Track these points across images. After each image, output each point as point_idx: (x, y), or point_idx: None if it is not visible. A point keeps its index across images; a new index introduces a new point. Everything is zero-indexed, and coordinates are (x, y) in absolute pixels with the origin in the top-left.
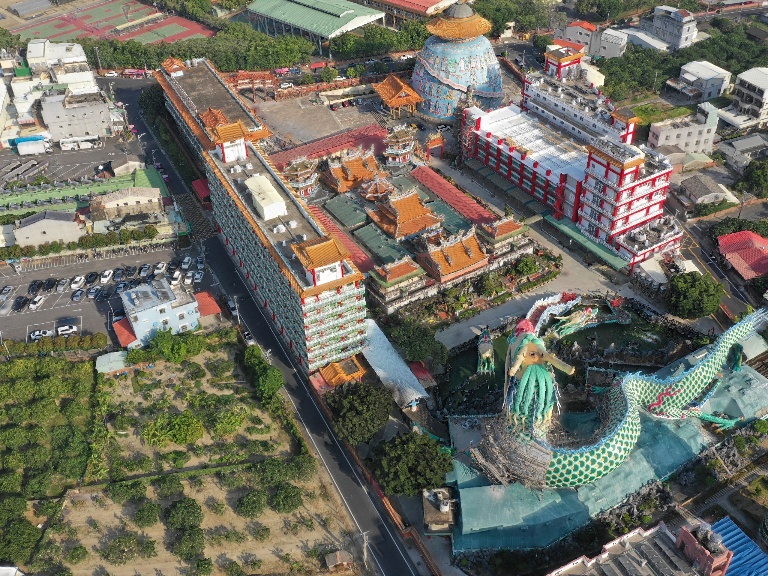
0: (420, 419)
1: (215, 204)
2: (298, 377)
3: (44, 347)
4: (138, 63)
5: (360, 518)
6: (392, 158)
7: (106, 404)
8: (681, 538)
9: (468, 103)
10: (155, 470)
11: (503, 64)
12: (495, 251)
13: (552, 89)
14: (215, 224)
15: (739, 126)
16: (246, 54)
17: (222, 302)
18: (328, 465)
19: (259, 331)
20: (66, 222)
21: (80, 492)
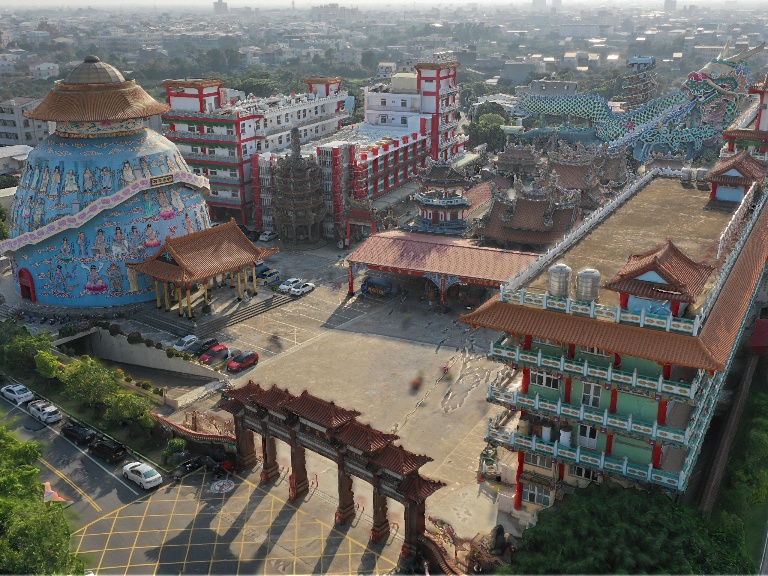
0: None
1: None
2: None
3: None
4: None
5: None
6: None
7: None
8: None
9: None
10: None
11: None
12: None
13: None
14: None
15: None
16: (52, 522)
17: None
18: None
19: None
20: None
21: None
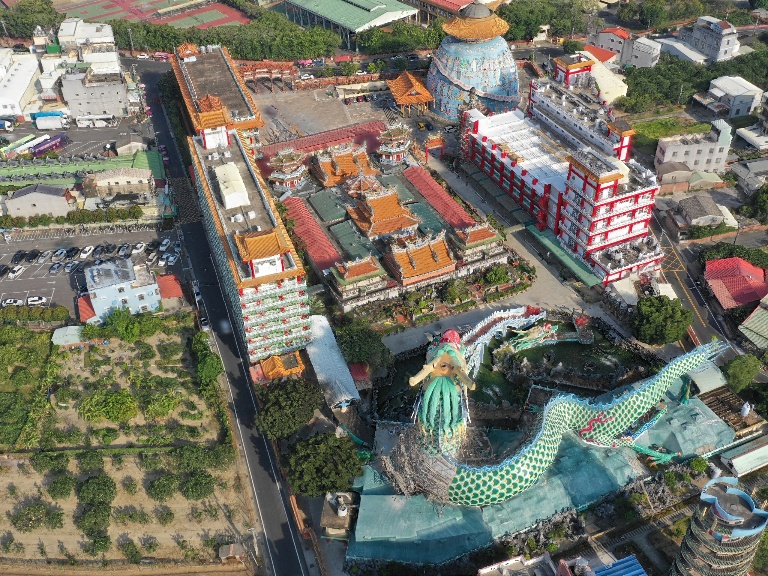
0: (347, 421)
1: (198, 189)
2: (242, 367)
3: (8, 315)
4: (168, 47)
5: (266, 513)
6: (386, 156)
7: (53, 375)
8: (560, 571)
9: (471, 105)
10: (84, 444)
11: (529, 68)
12: (465, 258)
13: (556, 96)
14: (201, 209)
15: (759, 147)
16: (271, 43)
17: (188, 286)
18: (249, 457)
19: (217, 318)
20: (55, 196)
21: (9, 458)
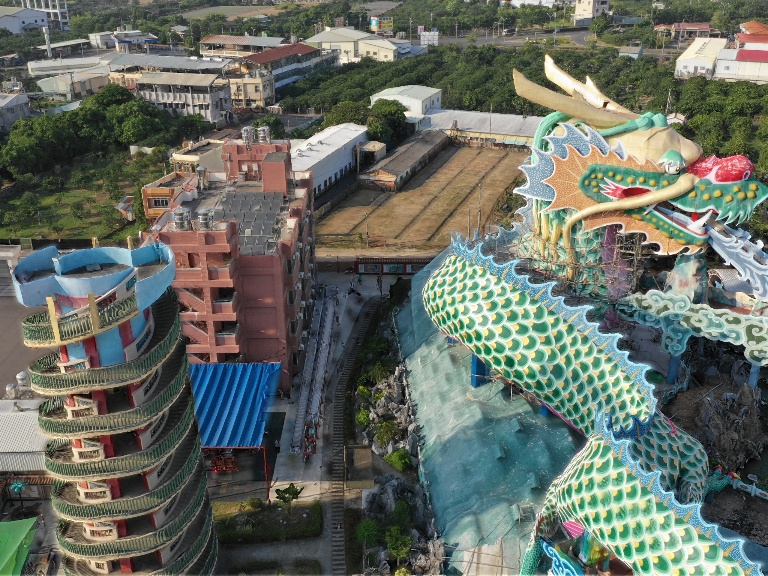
0: None
1: None
2: None
3: None
4: None
5: None
6: None
7: None
8: None
9: None
10: None
11: None
12: None
13: None
14: None
15: None
16: None
17: None
18: None
19: None
20: None
21: None
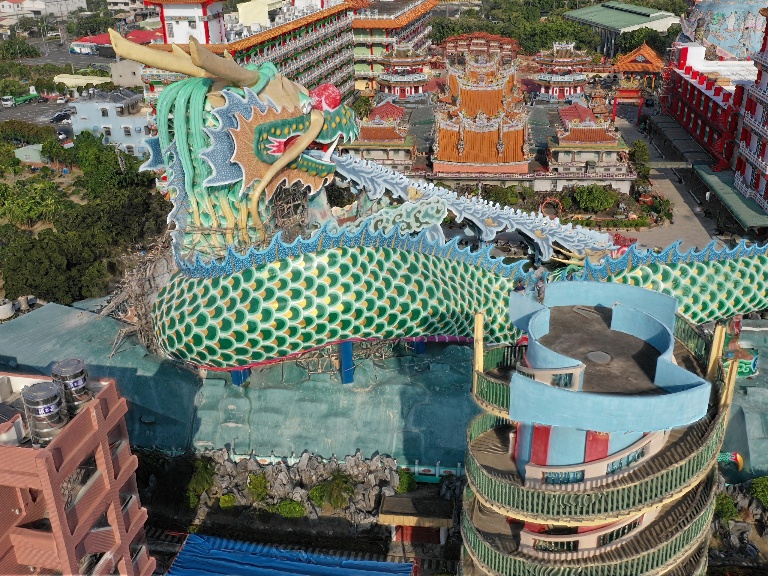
0: None
1: None
2: None
3: (4, 127)
4: None
5: None
6: (545, 89)
7: None
8: None
9: None
10: None
11: None
12: (552, 163)
13: None
14: None
15: None
16: (512, 31)
17: None
18: None
19: None
20: None
21: None
